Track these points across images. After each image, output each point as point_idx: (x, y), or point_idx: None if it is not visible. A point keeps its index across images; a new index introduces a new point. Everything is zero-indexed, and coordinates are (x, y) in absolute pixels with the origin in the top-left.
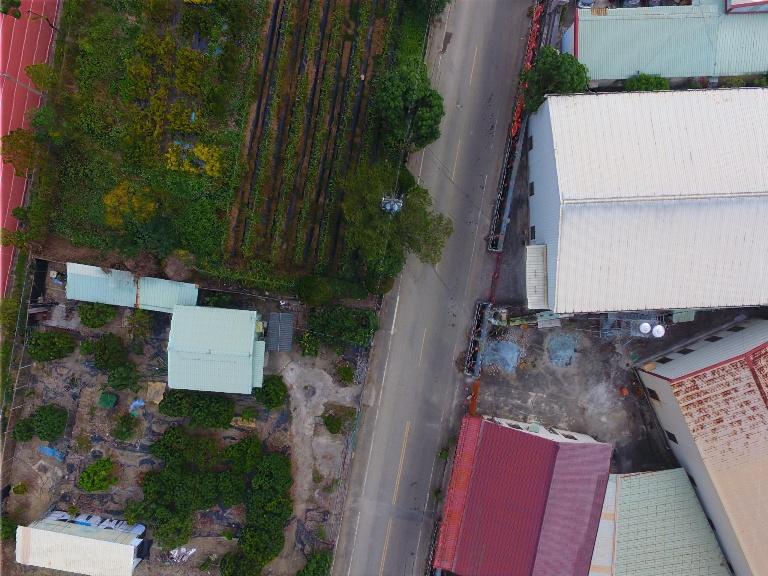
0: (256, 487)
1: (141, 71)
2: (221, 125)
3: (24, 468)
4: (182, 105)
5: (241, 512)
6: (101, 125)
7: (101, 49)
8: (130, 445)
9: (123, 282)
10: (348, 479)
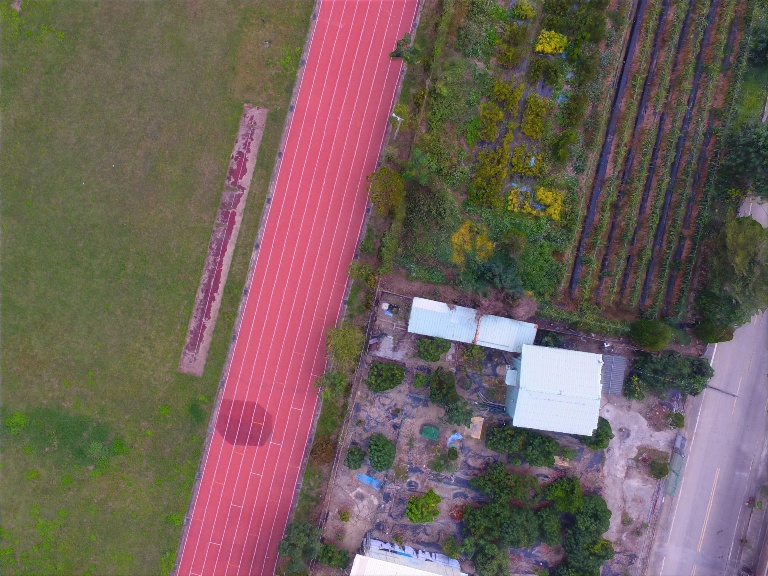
0: (583, 528)
1: (495, 116)
2: (562, 170)
3: (342, 495)
4: (523, 149)
5: (550, 551)
6: (448, 165)
7: (452, 92)
8: (445, 478)
9: (465, 318)
10: (657, 523)
